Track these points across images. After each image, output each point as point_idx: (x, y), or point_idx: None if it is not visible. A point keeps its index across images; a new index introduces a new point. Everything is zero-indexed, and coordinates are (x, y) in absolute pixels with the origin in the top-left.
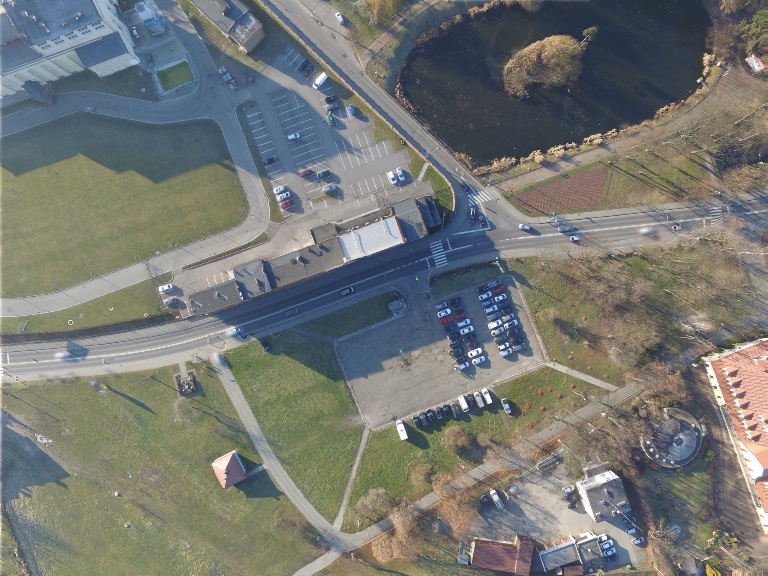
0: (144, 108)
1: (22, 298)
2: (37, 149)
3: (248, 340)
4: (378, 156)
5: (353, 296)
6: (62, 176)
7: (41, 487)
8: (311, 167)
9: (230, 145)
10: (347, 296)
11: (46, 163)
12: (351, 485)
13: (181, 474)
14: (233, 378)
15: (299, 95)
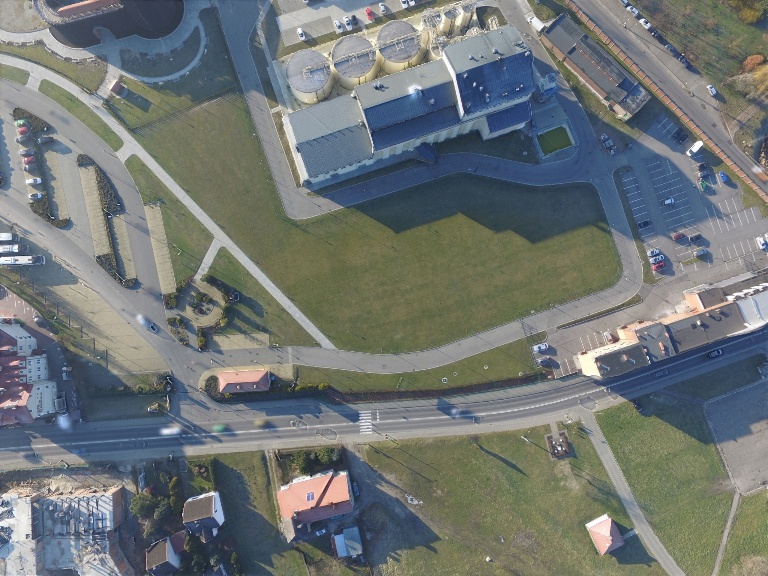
0: (524, 170)
1: (397, 355)
2: (418, 207)
3: (618, 401)
4: (746, 222)
5: (721, 358)
6: (442, 234)
7: (410, 551)
8: (682, 231)
9: (606, 208)
10: (716, 358)
11: (426, 221)
12: (722, 552)
13: (554, 539)
14: (604, 439)
15: (671, 161)
